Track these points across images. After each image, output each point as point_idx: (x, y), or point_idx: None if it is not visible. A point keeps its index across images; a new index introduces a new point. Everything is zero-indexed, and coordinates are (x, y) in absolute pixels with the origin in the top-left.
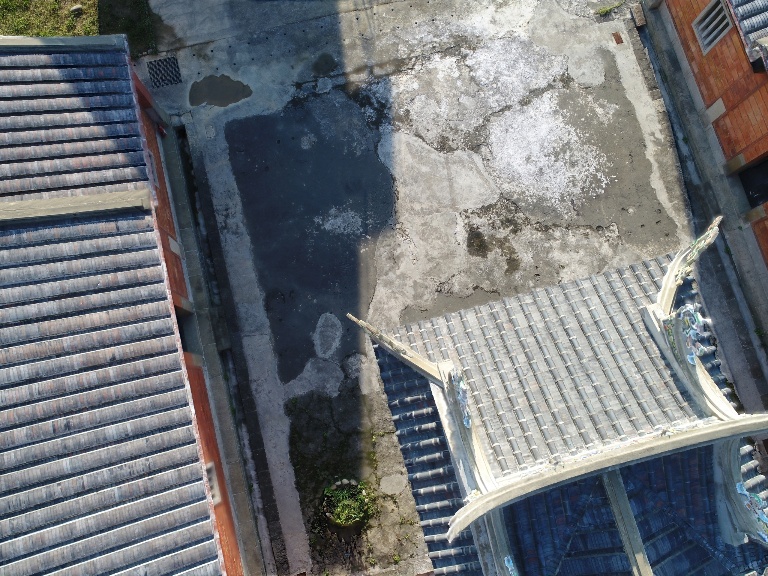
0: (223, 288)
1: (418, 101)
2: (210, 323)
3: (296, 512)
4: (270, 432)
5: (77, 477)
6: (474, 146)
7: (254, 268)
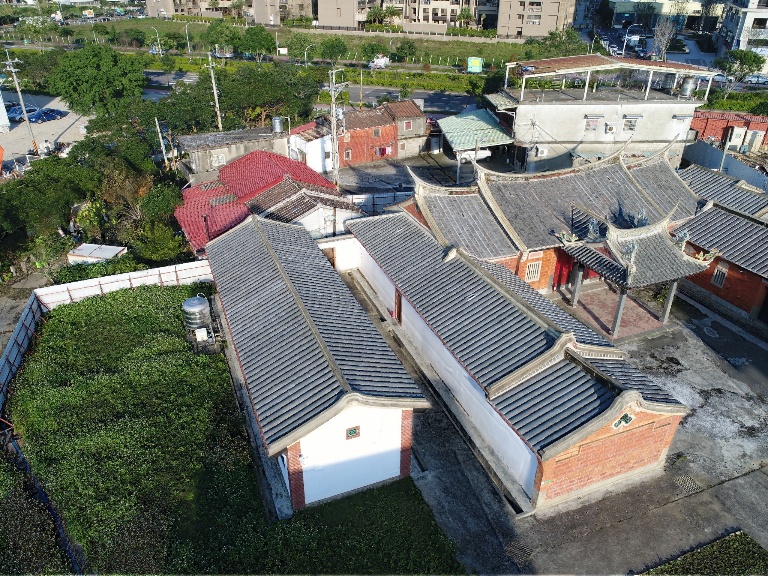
0: (766, 341)
1: (748, 406)
2: (760, 329)
3: (680, 296)
4: (707, 310)
5: (760, 245)
6: (704, 392)
7: (760, 346)
